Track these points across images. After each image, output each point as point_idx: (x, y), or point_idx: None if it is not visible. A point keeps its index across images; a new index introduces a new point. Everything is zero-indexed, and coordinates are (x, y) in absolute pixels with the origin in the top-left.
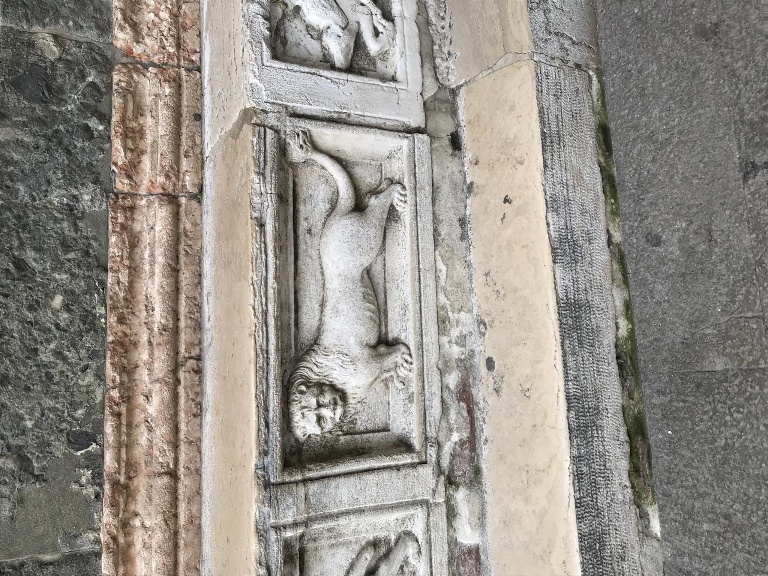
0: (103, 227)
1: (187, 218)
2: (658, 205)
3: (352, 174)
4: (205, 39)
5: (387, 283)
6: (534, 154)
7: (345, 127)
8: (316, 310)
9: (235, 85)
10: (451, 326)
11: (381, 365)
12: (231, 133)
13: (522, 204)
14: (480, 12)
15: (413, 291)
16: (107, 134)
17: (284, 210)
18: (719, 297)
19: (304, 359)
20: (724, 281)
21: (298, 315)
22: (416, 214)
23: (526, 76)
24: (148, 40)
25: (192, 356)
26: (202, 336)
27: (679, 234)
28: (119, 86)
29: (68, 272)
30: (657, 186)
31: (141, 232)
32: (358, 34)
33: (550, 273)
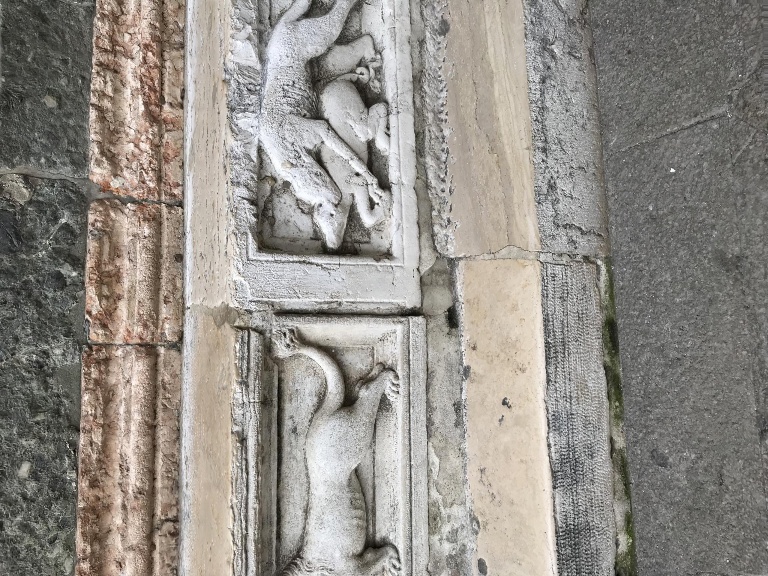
0: (75, 382)
1: (166, 369)
2: (666, 424)
3: (342, 361)
4: (188, 177)
5: (376, 478)
6: (537, 366)
7: (335, 319)
8: (300, 516)
9: (218, 268)
10: (442, 522)
11: (367, 575)
12: (213, 314)
13: (522, 415)
14: (483, 189)
15: (403, 490)
16: (81, 279)
17: (268, 413)
18: (728, 548)
19: (286, 575)
20: (734, 533)
21: (280, 525)
22: (409, 405)
23: (531, 278)
24: (127, 173)
25: (169, 518)
26: (180, 496)
27: (687, 463)
28: (95, 227)
29: (37, 435)
30: (666, 404)
31: (116, 384)
32: (352, 205)
33: (550, 500)
